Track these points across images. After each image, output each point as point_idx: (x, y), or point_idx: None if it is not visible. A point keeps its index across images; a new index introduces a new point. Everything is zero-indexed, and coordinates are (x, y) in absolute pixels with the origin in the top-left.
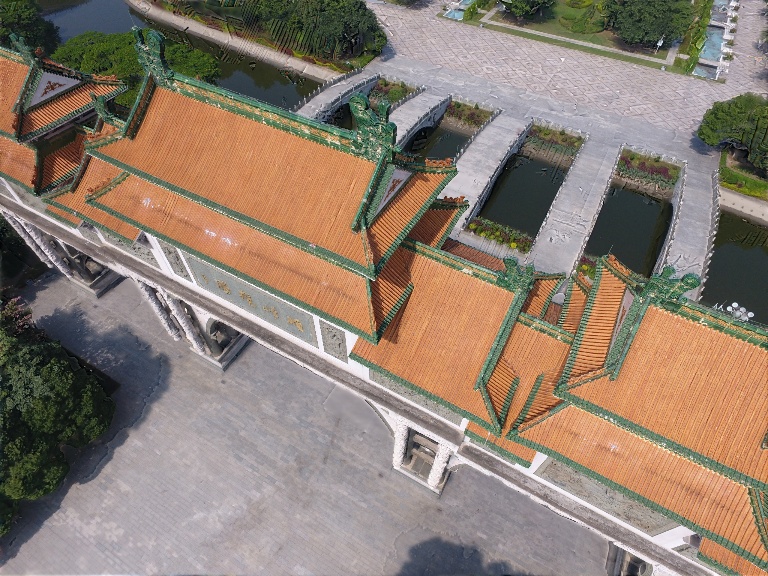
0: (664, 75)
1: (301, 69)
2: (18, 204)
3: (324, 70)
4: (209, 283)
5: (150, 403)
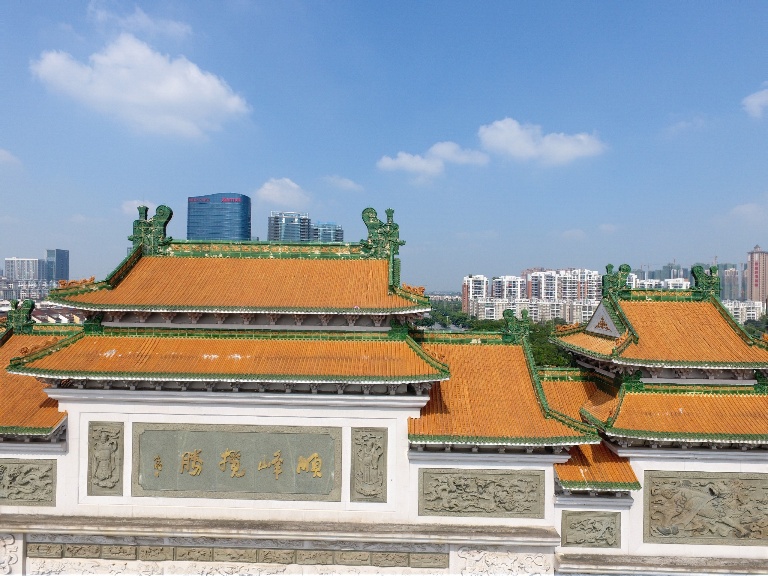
0: None
1: None
2: None
3: None
4: (162, 473)
5: None
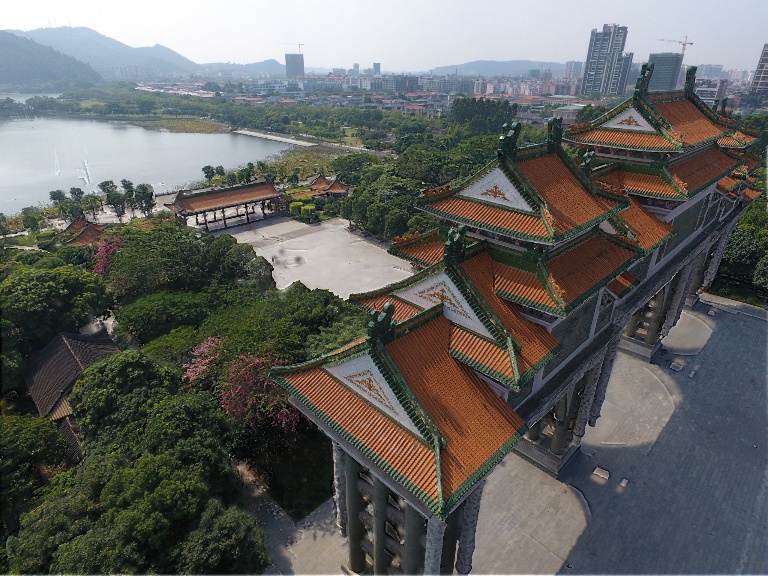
0: None
1: None
2: None
3: None
4: None
5: None
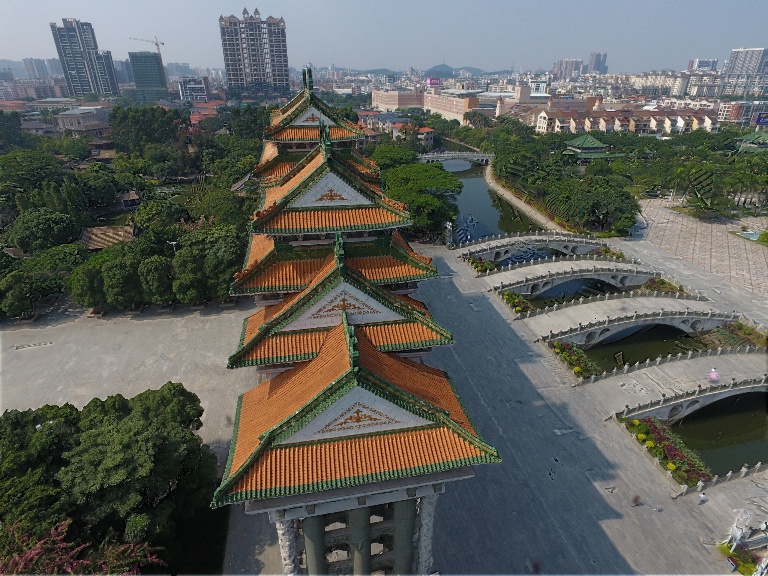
0: None
1: (552, 229)
2: None
3: None
4: None
5: (257, 309)
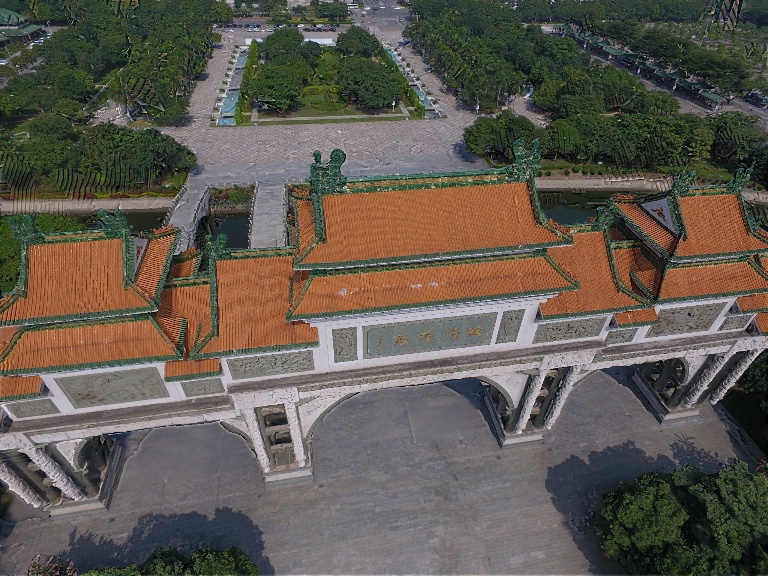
0: (411, 123)
1: (115, 207)
2: (61, 415)
3: (143, 200)
4: (383, 347)
5: (271, 553)
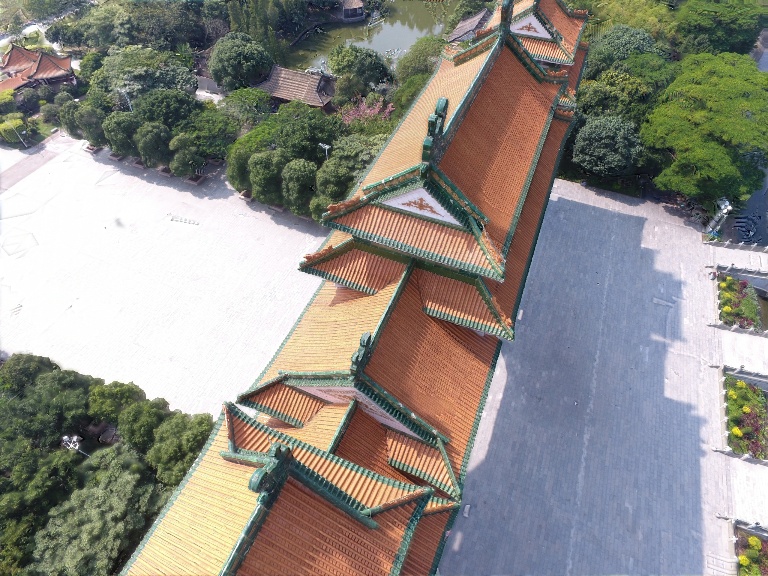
0: None
1: None
2: None
3: None
4: None
5: None
